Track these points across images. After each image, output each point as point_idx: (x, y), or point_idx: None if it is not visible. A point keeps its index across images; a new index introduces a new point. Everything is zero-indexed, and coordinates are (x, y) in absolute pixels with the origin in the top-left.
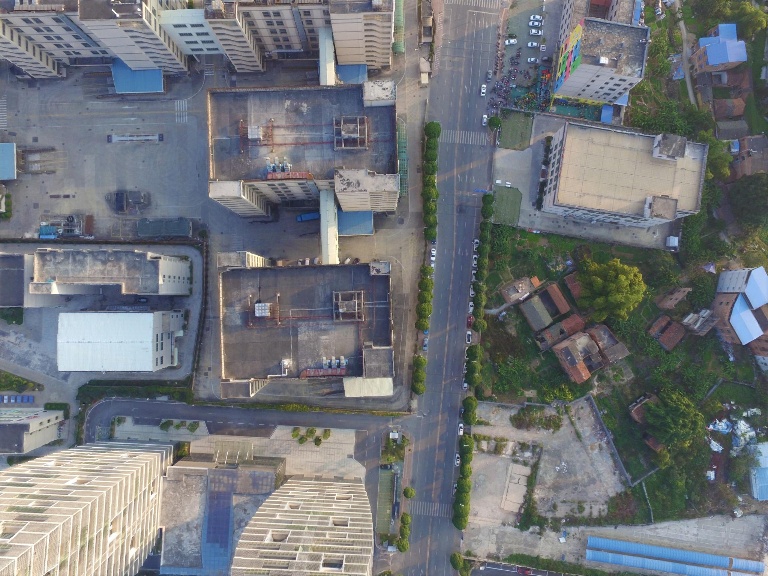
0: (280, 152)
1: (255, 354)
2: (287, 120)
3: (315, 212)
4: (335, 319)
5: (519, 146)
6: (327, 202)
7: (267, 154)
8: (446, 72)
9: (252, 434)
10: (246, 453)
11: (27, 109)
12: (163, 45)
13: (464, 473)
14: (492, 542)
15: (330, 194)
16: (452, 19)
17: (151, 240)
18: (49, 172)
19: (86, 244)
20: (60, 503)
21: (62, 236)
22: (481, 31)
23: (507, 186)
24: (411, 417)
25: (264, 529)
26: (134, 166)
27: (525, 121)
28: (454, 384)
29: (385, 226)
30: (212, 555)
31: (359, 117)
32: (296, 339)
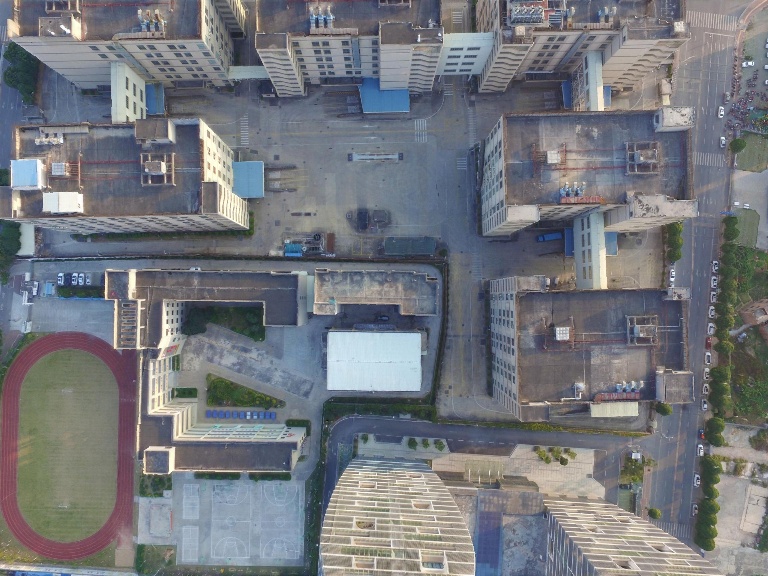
0: (572, 176)
1: (548, 377)
2: (578, 145)
3: (557, 232)
4: (630, 343)
5: (756, 168)
6: (598, 225)
7: (559, 178)
8: (683, 94)
9: (492, 453)
10: (497, 472)
11: (268, 127)
12: (435, 67)
13: (713, 495)
14: (731, 563)
15: (600, 217)
16: (688, 41)
17: (392, 258)
18: (291, 190)
19: (327, 262)
20: (442, 530)
21: (305, 254)
22: (717, 53)
23: (745, 208)
24: (650, 437)
25: (603, 555)
26: (374, 185)
27: (762, 143)
28: (693, 405)
29: (623, 246)
30: (483, 575)
31: (652, 142)
32: (589, 363)
